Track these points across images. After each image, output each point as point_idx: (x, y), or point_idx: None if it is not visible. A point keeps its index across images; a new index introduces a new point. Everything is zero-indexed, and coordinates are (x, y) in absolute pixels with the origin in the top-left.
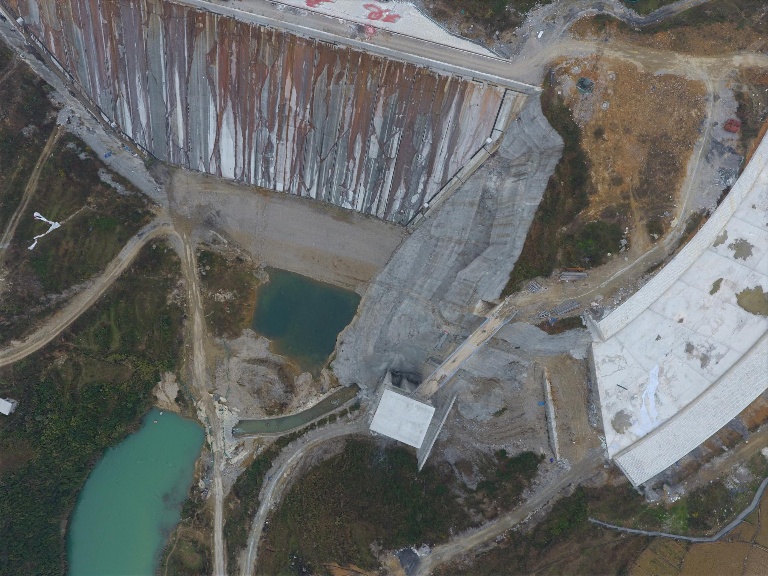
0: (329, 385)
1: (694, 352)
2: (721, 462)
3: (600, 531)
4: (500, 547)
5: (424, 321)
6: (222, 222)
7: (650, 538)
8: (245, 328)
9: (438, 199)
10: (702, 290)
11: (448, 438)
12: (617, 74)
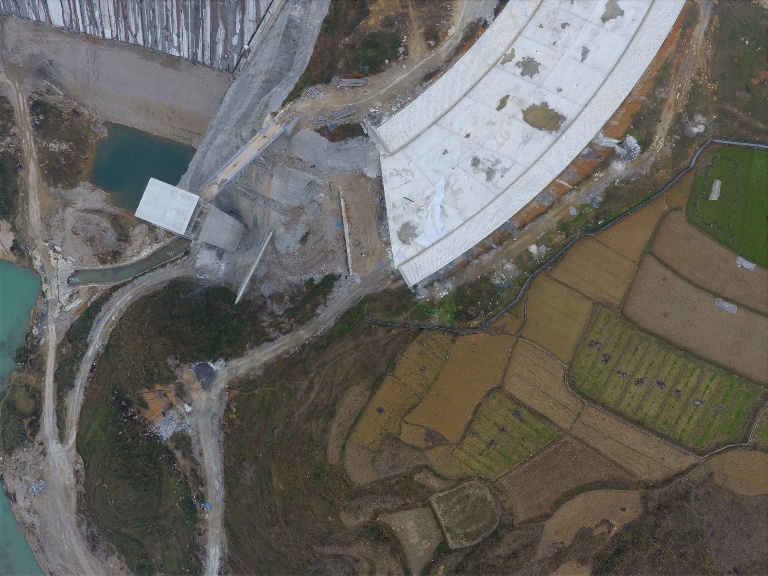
0: (164, 236)
1: (480, 166)
2: (489, 258)
3: (374, 329)
4: None
5: (227, 146)
6: (56, 73)
7: (417, 331)
8: (83, 181)
9: (257, 40)
10: (489, 106)
11: (265, 274)
12: None
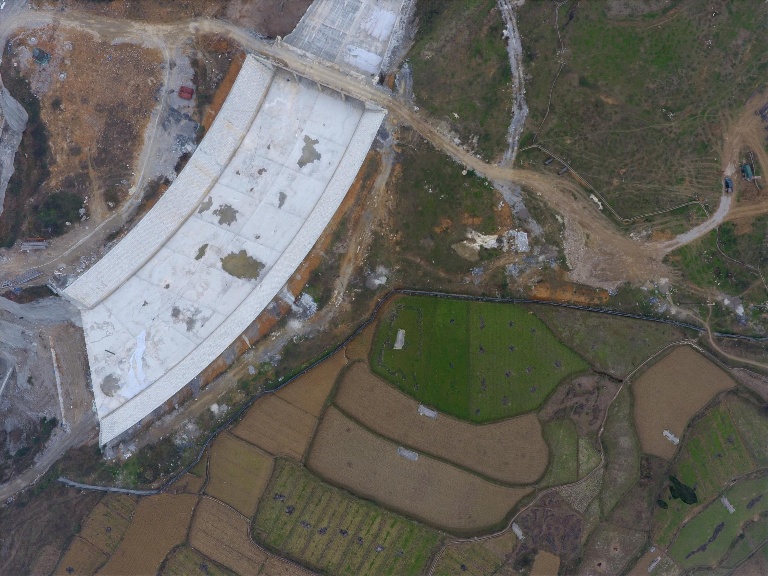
0: None
1: (180, 316)
2: (171, 419)
3: (66, 489)
4: (4, 508)
5: None
6: None
7: (101, 493)
8: None
9: None
10: (188, 256)
11: (9, 408)
12: (73, 44)
